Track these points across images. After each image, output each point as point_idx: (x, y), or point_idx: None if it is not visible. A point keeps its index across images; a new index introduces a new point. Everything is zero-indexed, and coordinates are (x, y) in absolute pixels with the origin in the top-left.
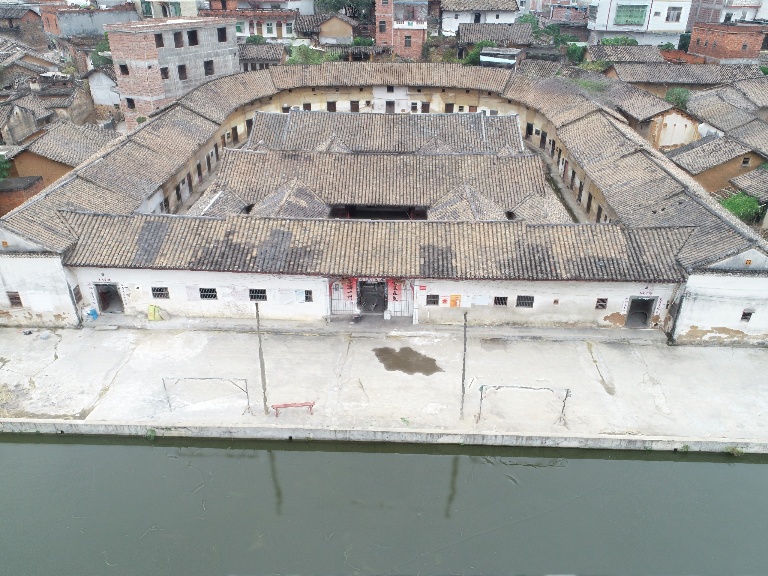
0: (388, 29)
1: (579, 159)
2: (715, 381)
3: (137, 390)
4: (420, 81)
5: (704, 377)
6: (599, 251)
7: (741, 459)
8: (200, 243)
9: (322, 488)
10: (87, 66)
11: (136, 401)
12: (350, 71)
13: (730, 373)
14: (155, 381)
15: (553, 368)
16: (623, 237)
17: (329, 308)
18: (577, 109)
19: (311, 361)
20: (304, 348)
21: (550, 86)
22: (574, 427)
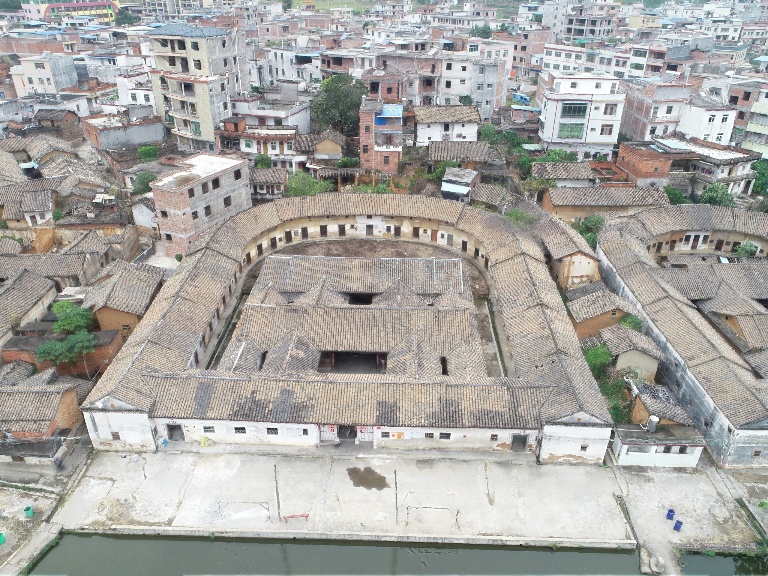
0: (370, 151)
1: (501, 303)
2: (558, 494)
3: (200, 503)
4: (393, 212)
5: (552, 491)
6: (491, 406)
7: (560, 550)
8: (235, 399)
9: (313, 571)
10: (125, 182)
11: (200, 512)
12: (338, 202)
13: (570, 487)
14: (210, 496)
15: (459, 484)
16: (508, 394)
17: (319, 439)
18: (508, 248)
19: (307, 479)
20: (302, 468)
21: (492, 221)
22: (464, 529)
